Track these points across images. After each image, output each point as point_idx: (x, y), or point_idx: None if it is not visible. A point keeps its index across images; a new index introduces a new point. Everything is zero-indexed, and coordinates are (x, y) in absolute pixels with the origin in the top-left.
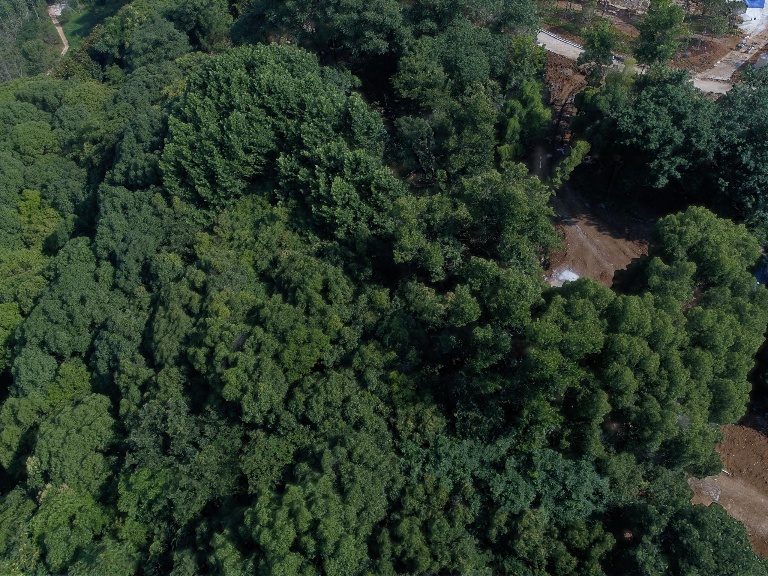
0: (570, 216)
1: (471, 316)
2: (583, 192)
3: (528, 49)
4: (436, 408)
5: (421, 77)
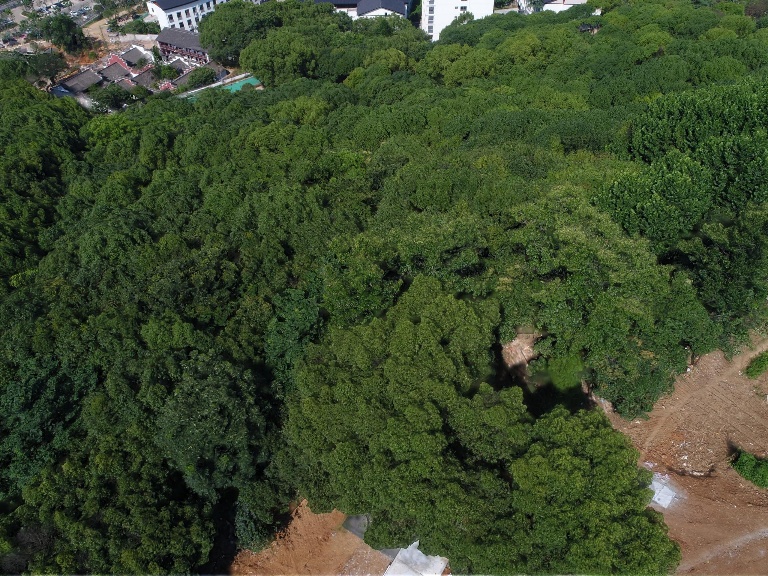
0: None
1: None
2: None
3: None
4: None
5: None
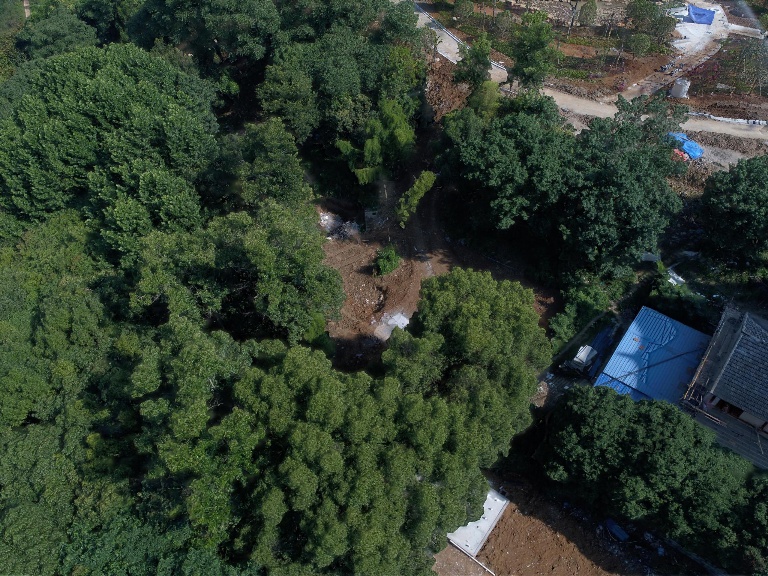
0: (426, 251)
1: (143, 387)
2: (448, 224)
3: (399, 63)
4: (127, 482)
5: (282, 88)
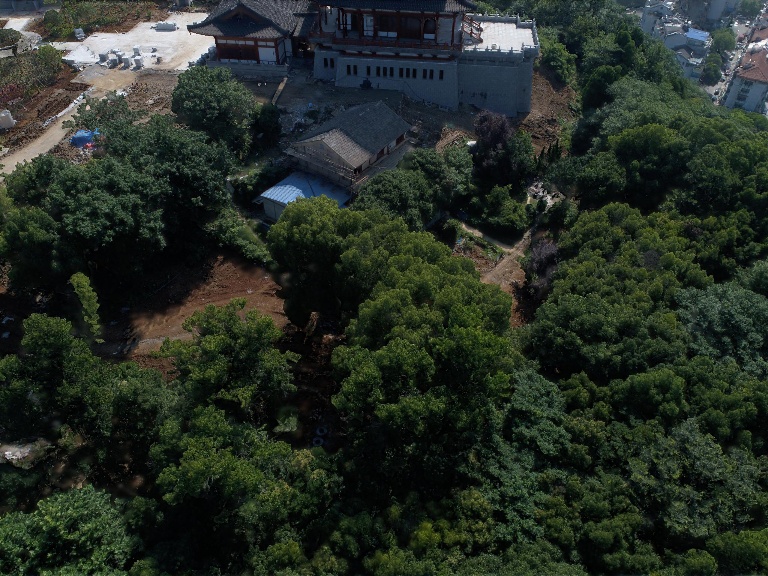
0: (121, 344)
1: None
2: None
3: None
4: None
5: None
